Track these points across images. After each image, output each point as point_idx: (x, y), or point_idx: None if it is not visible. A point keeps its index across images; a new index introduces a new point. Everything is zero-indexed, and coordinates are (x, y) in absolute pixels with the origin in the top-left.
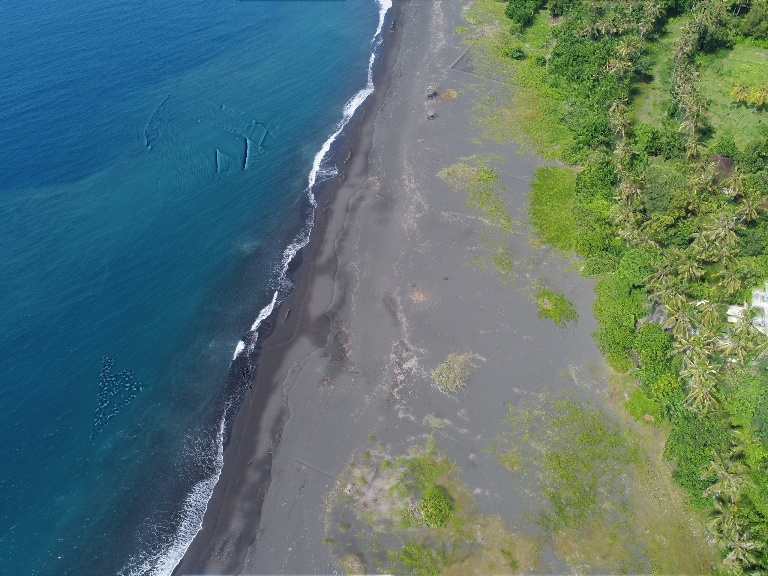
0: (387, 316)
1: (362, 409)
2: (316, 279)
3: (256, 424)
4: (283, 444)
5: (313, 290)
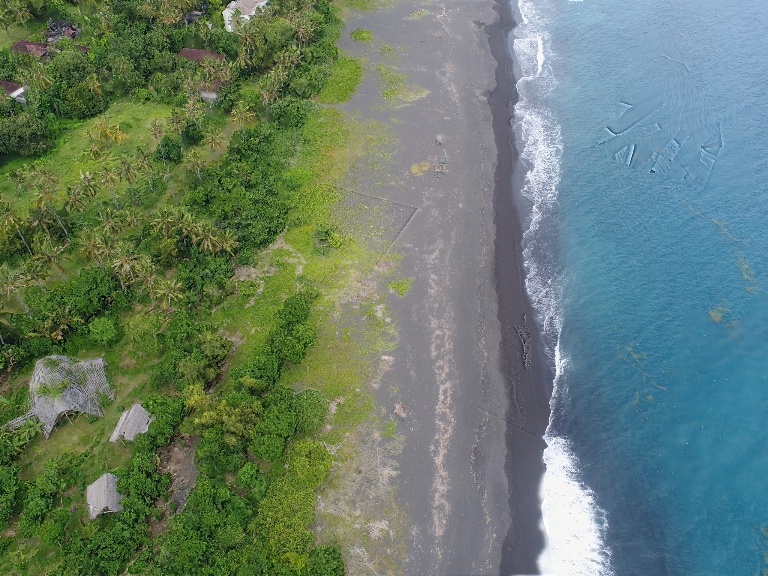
0: (454, 30)
1: (460, 7)
2: (502, 49)
3: (507, 8)
4: (491, 2)
5: (502, 45)
